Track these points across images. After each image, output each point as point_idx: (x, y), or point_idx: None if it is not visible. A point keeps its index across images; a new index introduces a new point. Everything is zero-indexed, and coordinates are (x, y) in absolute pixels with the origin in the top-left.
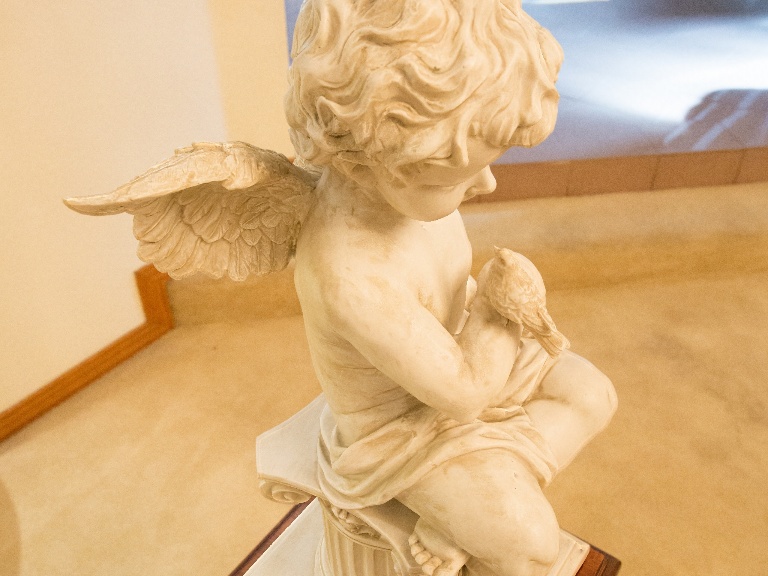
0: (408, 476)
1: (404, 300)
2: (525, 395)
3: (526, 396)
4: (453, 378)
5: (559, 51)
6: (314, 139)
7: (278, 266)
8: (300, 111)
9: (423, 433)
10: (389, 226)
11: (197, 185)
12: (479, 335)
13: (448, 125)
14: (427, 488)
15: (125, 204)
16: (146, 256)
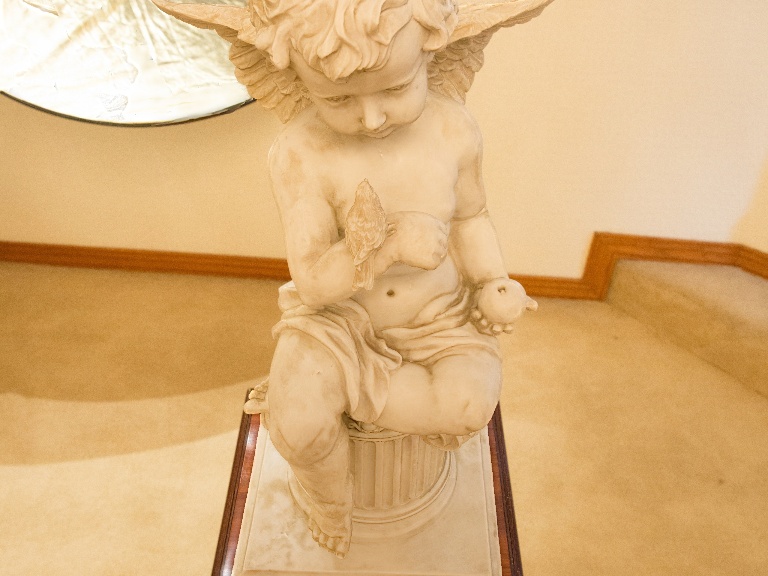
0: None
1: (305, 182)
2: (418, 356)
3: (418, 357)
4: (298, 257)
5: (373, 14)
6: None
7: None
8: None
9: None
10: None
11: None
12: (338, 244)
13: (274, 30)
14: (279, 339)
15: None
16: (238, 77)
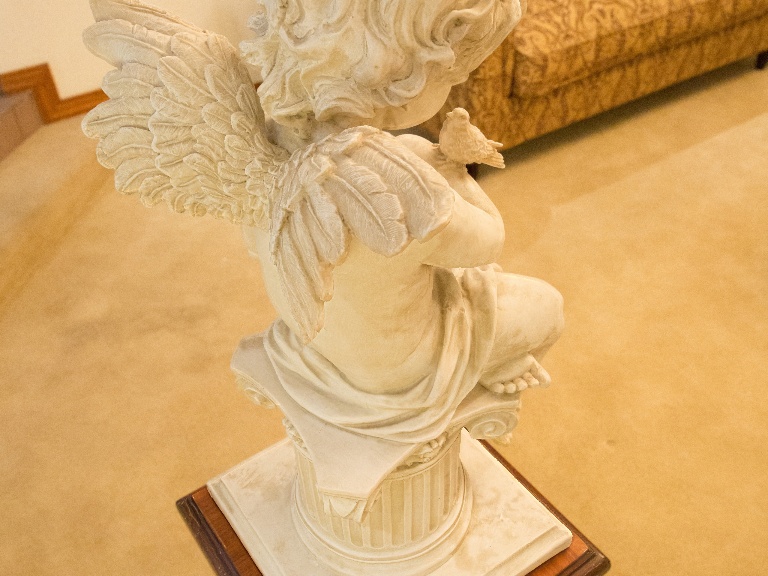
0: (491, 335)
1: None
2: None
3: None
4: (495, 223)
5: None
6: (446, 60)
7: (332, 266)
8: (404, 51)
9: (464, 305)
10: None
11: None
12: (468, 189)
13: None
14: (501, 331)
15: None
16: None
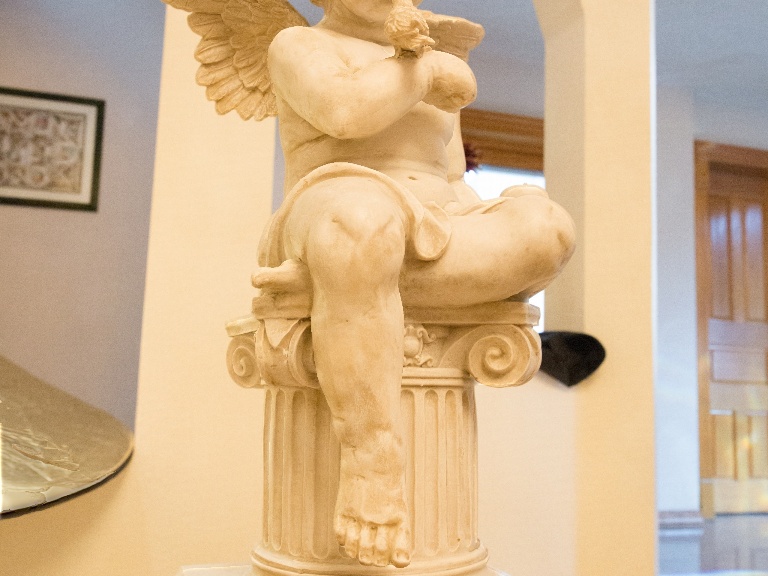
0: None
1: None
2: None
3: None
4: (328, 76)
5: None
6: None
7: None
8: None
9: None
10: (349, 35)
11: (246, 36)
12: None
13: None
14: None
15: None
16: (199, 78)
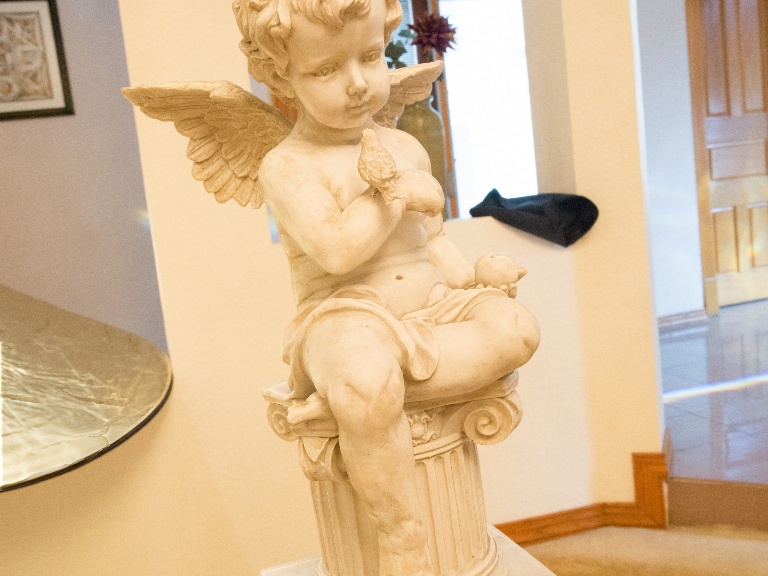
0: None
1: (303, 173)
2: (447, 318)
3: (448, 319)
4: (317, 223)
5: None
6: None
7: None
8: None
9: None
10: (325, 144)
11: (229, 130)
12: None
13: (276, 2)
14: (307, 338)
15: (147, 92)
16: (195, 174)
